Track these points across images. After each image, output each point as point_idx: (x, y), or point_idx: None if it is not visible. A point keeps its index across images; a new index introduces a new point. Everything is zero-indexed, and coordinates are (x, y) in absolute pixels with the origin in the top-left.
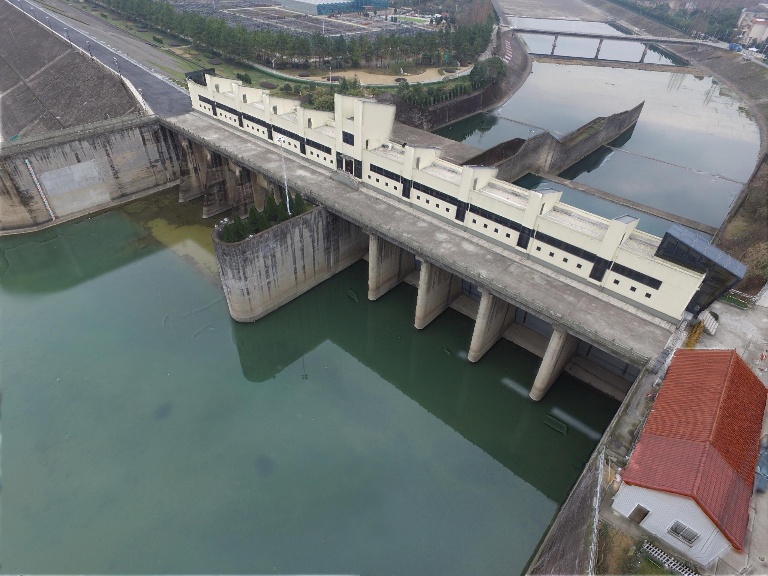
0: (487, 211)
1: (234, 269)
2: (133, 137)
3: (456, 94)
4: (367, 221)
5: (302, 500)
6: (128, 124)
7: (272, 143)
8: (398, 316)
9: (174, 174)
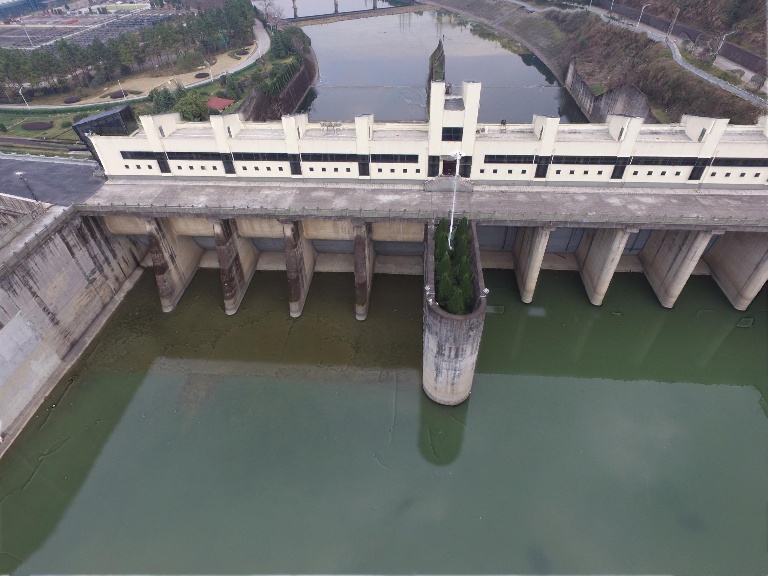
0: (654, 157)
1: (474, 343)
2: (55, 250)
3: (290, 74)
4: (550, 216)
5: (763, 527)
6: (43, 233)
7: (300, 178)
8: (568, 304)
9: (116, 280)
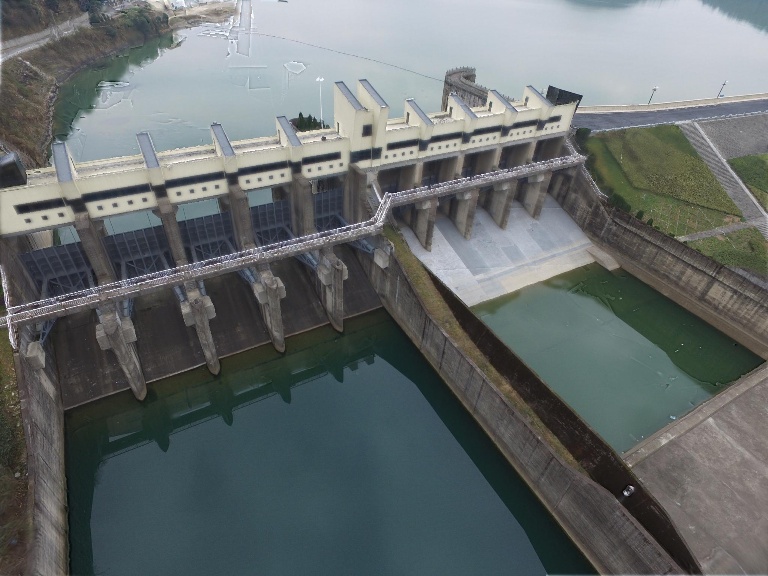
0: None
1: None
2: None
3: None
4: None
5: None
6: None
7: None
8: None
9: None
